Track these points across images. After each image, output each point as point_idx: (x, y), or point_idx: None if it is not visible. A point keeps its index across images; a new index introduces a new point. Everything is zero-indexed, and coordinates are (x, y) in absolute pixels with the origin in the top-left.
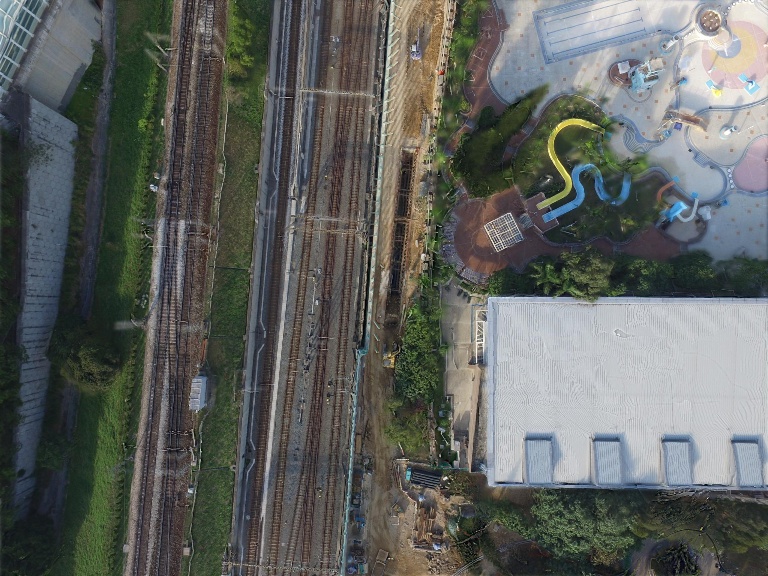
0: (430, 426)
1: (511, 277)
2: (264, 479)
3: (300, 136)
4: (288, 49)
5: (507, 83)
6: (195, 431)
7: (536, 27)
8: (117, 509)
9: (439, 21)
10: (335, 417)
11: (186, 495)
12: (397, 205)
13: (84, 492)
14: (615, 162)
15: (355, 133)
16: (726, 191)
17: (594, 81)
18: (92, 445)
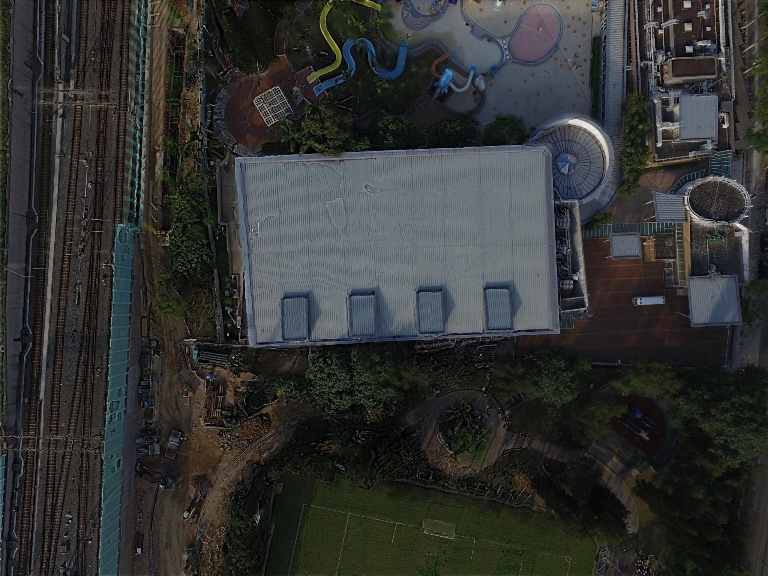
0: (215, 305)
1: (270, 144)
2: (42, 362)
3: (58, 16)
4: None
5: None
6: None
7: None
8: None
9: None
10: (112, 298)
11: None
12: (171, 87)
13: None
14: (394, 39)
15: (122, 15)
16: (502, 62)
17: None
18: None
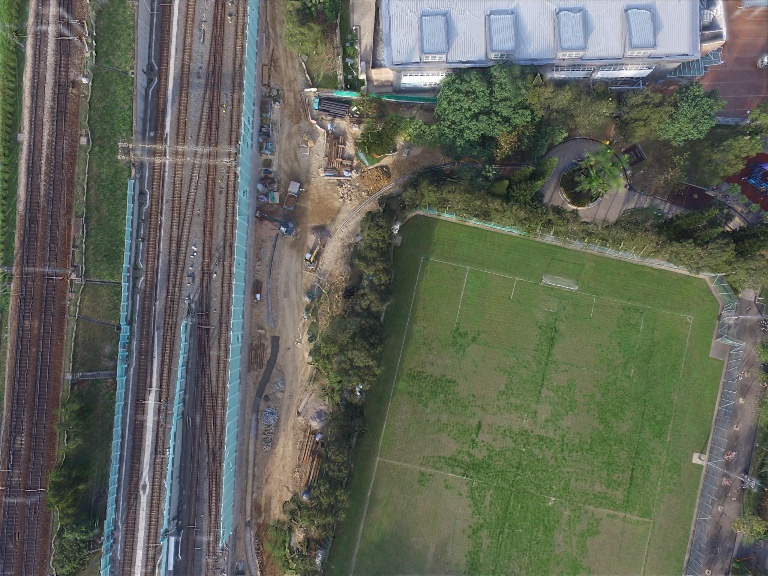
0: (337, 54)
1: None
2: (167, 97)
3: None
4: None
5: None
6: (88, 22)
7: None
8: (9, 95)
9: None
10: (238, 36)
11: (80, 85)
12: None
13: None
14: None
15: None
16: None
17: None
18: None
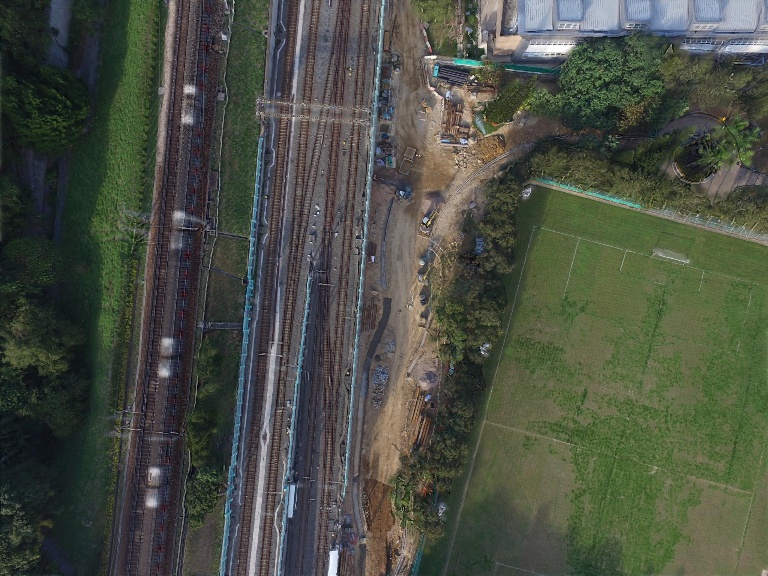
0: (458, 23)
1: None
2: (295, 58)
3: None
4: None
5: None
6: None
7: None
8: (152, 49)
9: None
10: (364, 1)
11: (220, 41)
12: None
13: (117, 62)
14: None
15: None
16: None
17: None
18: (124, 15)
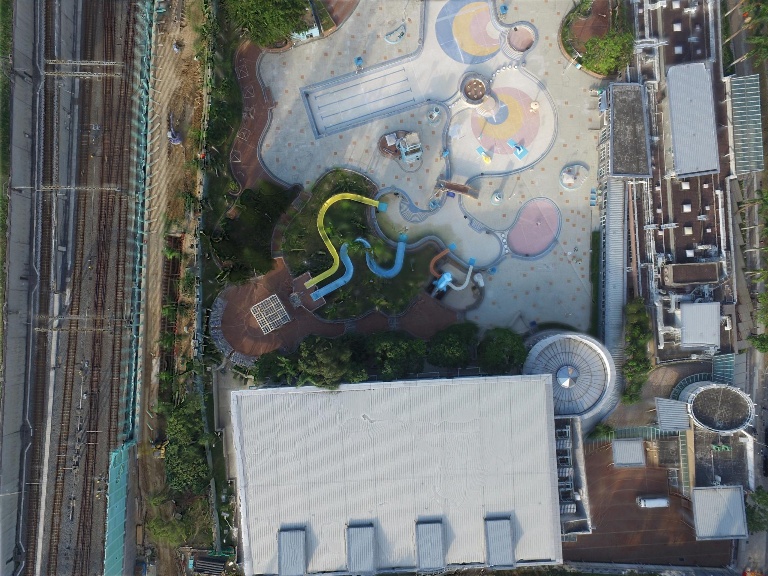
0: (211, 512)
1: (267, 364)
2: None
3: (55, 230)
4: (43, 141)
5: (278, 160)
6: None
7: (304, 103)
8: None
9: (199, 104)
10: None
11: None
12: (167, 291)
13: None
14: (392, 232)
15: (119, 221)
16: (501, 256)
17: (365, 154)
18: None
